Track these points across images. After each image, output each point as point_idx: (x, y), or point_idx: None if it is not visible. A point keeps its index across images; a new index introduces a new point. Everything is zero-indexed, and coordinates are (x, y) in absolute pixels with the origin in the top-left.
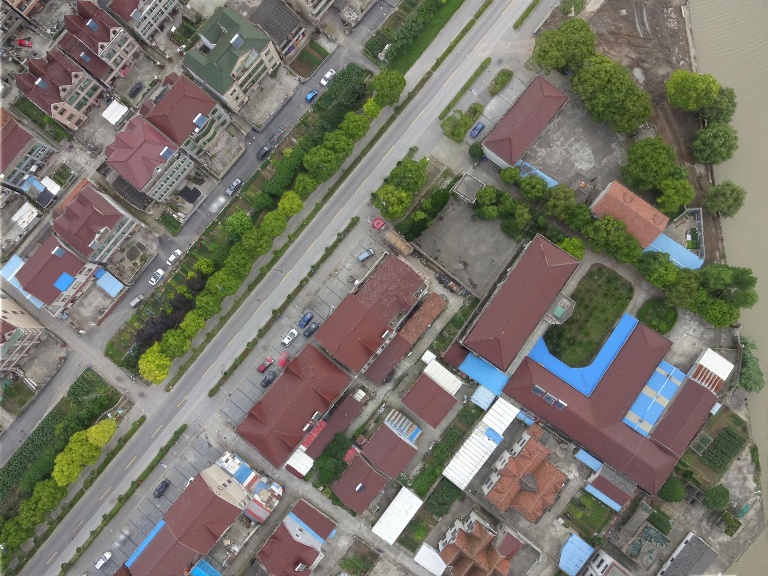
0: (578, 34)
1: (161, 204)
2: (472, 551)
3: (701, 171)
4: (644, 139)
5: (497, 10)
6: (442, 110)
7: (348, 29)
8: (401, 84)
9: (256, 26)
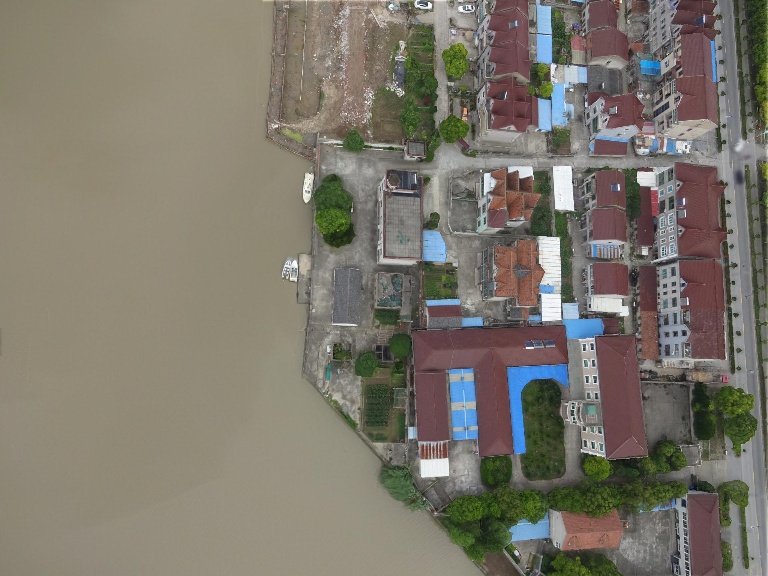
0: None
1: None
2: (525, 197)
3: None
4: None
5: None
6: None
7: None
8: None
9: None
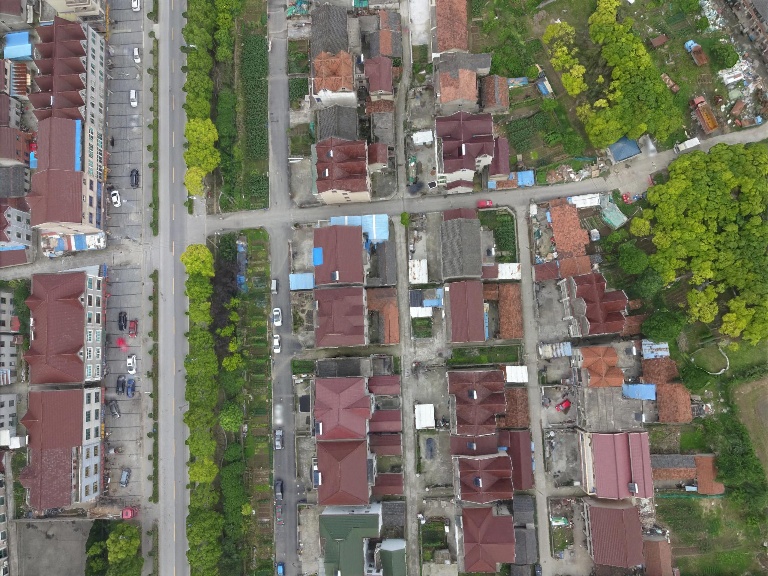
0: None
1: None
2: None
3: None
4: None
5: None
6: None
7: None
8: None
9: None
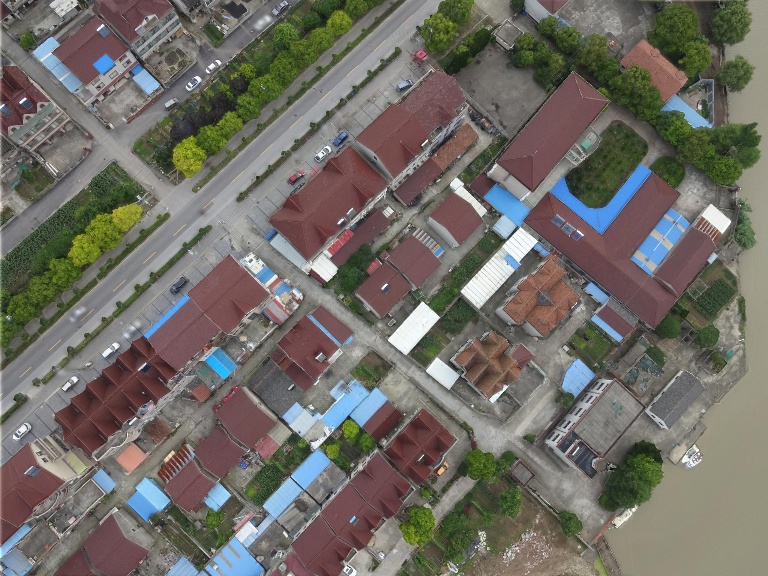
0: None
1: (205, 15)
2: (488, 354)
3: (714, 52)
4: (673, 4)
5: None
6: None
7: None
8: None
9: None
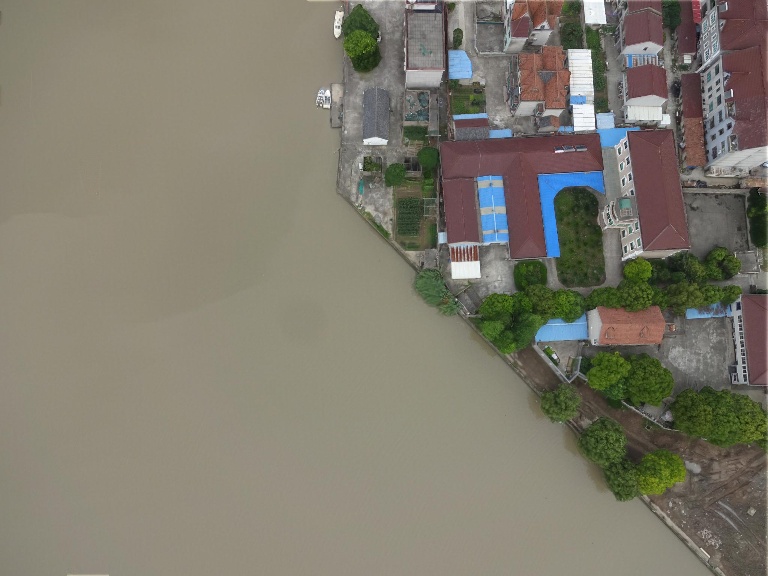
0: None
1: None
2: (547, 3)
3: (583, 422)
4: None
5: None
6: None
7: None
8: None
9: None
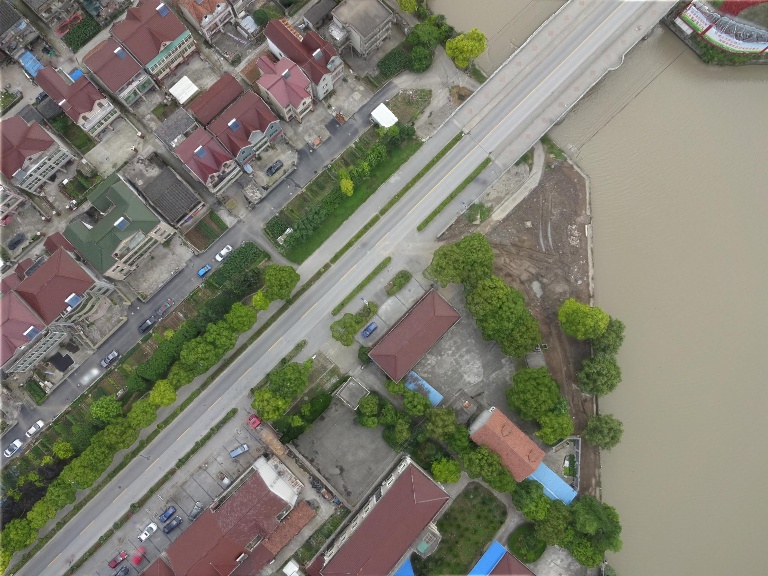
0: (476, 254)
1: None
2: None
3: (587, 395)
4: (529, 371)
5: (403, 209)
6: (336, 305)
7: (250, 206)
8: (293, 283)
9: (148, 202)
